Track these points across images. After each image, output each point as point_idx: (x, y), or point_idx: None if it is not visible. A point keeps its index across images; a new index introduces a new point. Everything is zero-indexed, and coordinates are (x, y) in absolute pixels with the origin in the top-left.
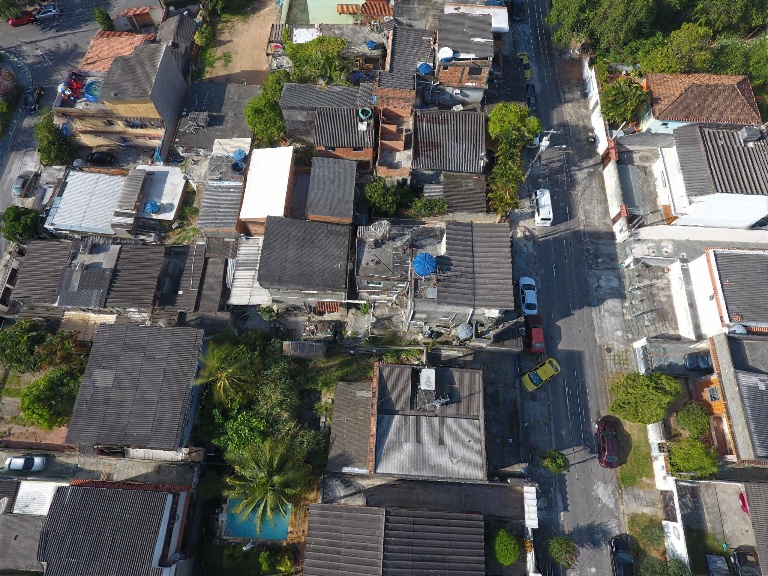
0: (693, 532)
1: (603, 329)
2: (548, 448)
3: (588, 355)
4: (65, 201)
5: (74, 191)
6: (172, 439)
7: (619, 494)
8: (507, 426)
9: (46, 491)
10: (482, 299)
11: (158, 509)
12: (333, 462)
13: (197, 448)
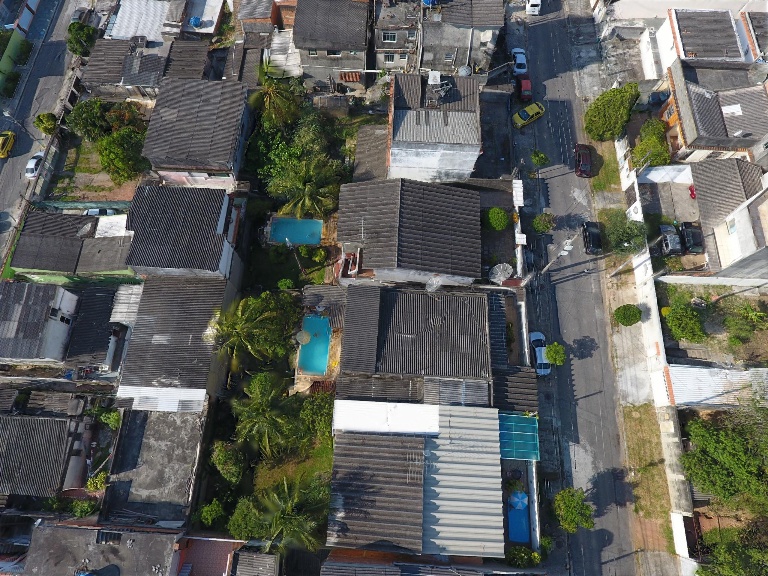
0: (650, 216)
1: (582, 86)
2: (534, 166)
3: (569, 104)
4: (120, 19)
5: (127, 11)
6: (227, 155)
7: (591, 196)
8: (500, 151)
9: (121, 220)
10: (478, 21)
11: (219, 199)
12: (357, 179)
13: (244, 181)
